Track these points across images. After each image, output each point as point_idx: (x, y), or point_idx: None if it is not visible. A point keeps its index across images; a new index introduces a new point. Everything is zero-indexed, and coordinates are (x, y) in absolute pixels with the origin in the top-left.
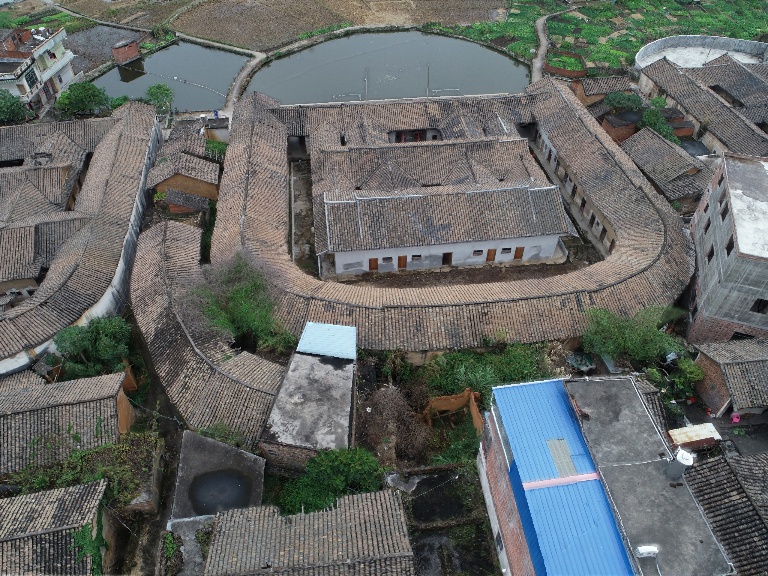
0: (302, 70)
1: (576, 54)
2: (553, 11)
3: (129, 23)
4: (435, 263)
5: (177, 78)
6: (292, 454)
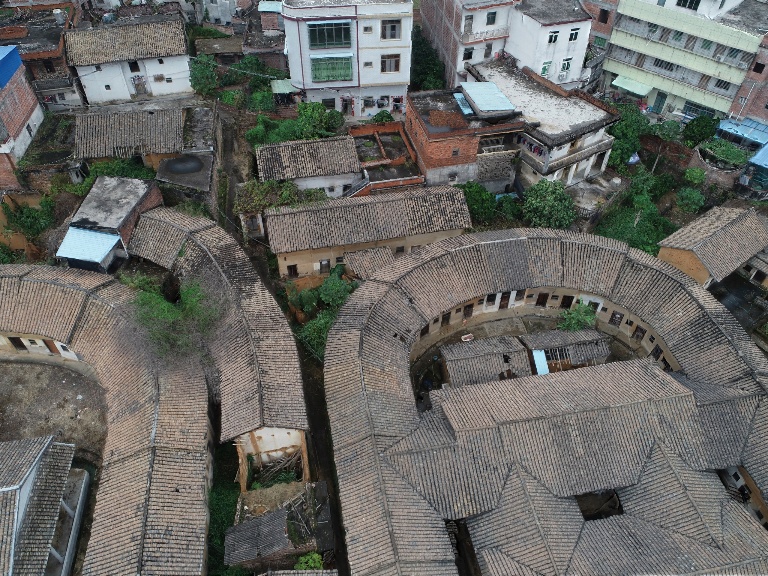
0: None
1: None
2: None
3: None
4: None
5: None
6: None
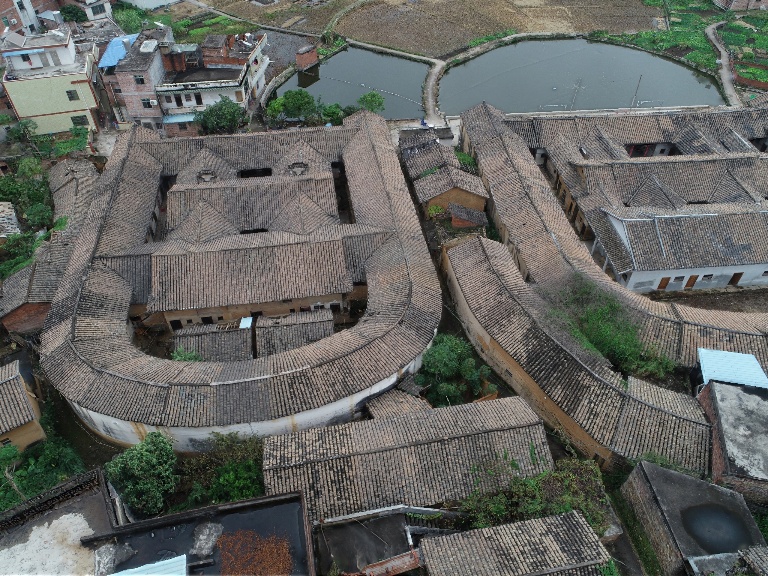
0: (483, 78)
1: (764, 66)
2: (716, 20)
3: (291, 27)
4: (722, 283)
5: (364, 85)
6: (753, 488)
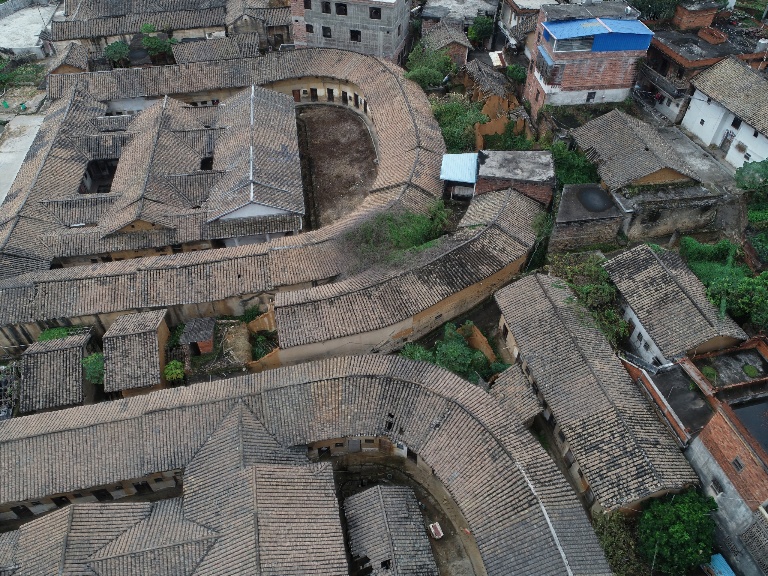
0: None
1: None
2: None
3: None
4: None
5: None
6: None
